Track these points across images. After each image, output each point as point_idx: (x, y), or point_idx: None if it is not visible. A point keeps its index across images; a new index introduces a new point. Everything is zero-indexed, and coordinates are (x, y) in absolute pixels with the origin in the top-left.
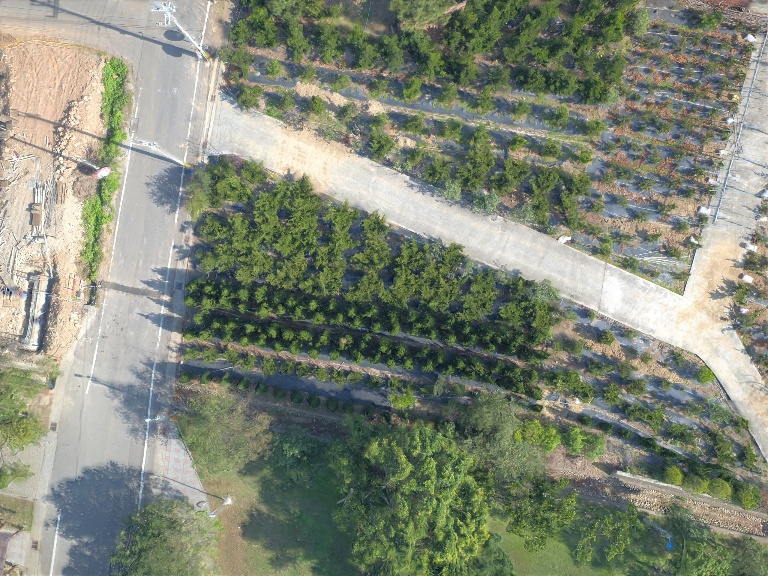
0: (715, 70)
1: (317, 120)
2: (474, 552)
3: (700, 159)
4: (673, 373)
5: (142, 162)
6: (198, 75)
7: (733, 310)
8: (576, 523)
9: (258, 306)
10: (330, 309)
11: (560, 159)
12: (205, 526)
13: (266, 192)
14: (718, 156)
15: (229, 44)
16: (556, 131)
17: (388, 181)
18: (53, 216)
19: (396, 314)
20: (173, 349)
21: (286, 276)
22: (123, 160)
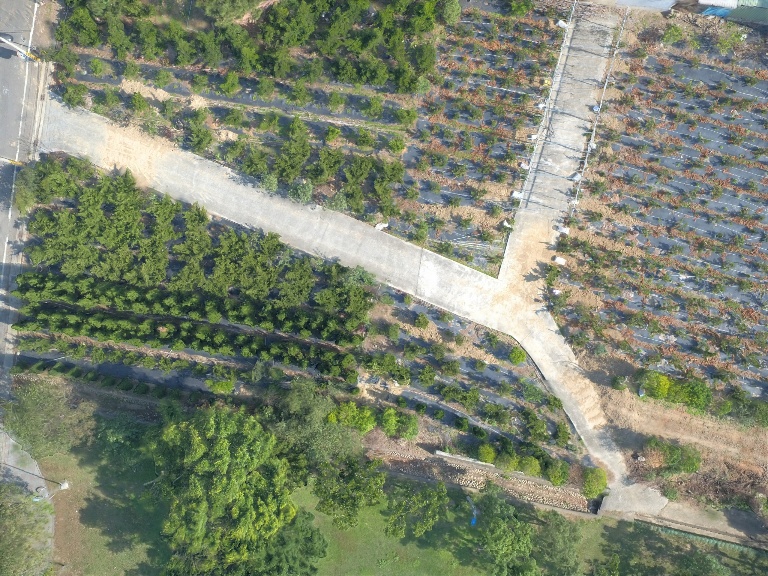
0: (528, 56)
1: (142, 116)
2: (272, 530)
3: (513, 144)
4: (489, 354)
5: None
6: (27, 75)
7: (547, 292)
8: (389, 501)
9: None
10: (151, 299)
11: (376, 148)
12: (34, 510)
13: None
14: (530, 141)
15: (57, 44)
16: (373, 121)
17: (210, 174)
18: None
19: (215, 302)
20: (10, 341)
21: (111, 268)
22: None
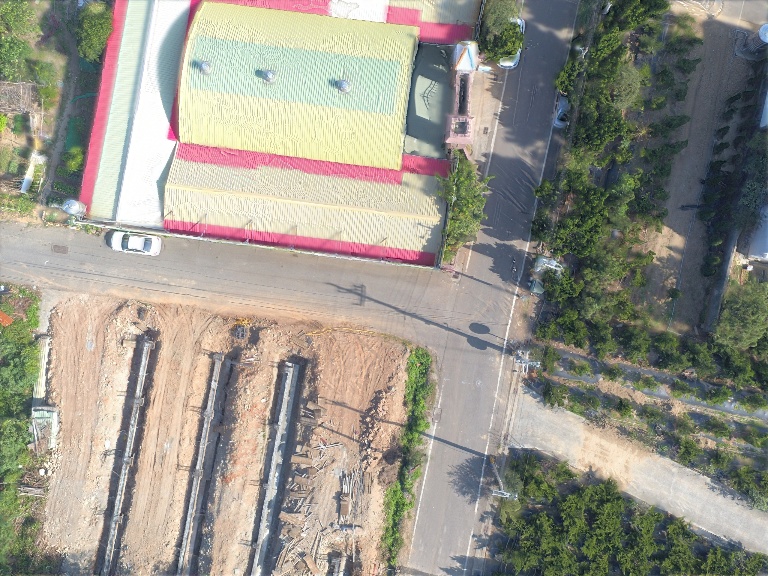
0: None
1: (619, 417)
2: None
3: None
4: None
5: (444, 452)
6: (502, 368)
7: None
8: None
9: None
10: None
11: None
12: None
13: (572, 493)
14: None
15: (532, 337)
16: None
17: (689, 482)
18: (359, 505)
19: None
20: None
21: None
22: (425, 449)
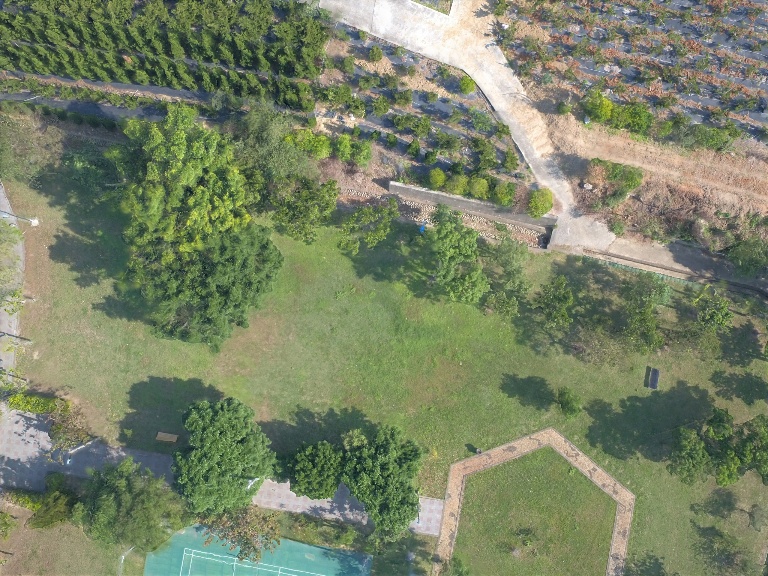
0: None
1: None
2: (227, 221)
3: None
4: (441, 88)
5: None
6: None
7: (496, 27)
8: None
9: None
10: (117, 33)
11: None
12: (4, 231)
13: None
14: None
15: None
16: None
17: None
18: None
19: (178, 36)
20: None
21: (79, 7)
22: None
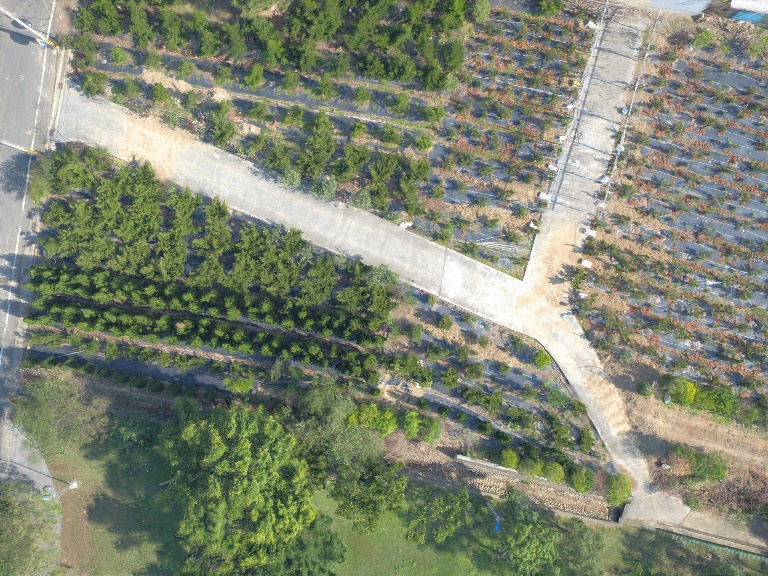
0: (557, 57)
1: (163, 107)
2: (292, 533)
3: (540, 145)
4: (513, 358)
5: None
6: (45, 63)
7: (572, 295)
8: (410, 506)
9: (97, 291)
10: (169, 294)
11: (402, 145)
12: (42, 509)
13: None
14: (558, 142)
15: (77, 32)
16: (399, 118)
17: (232, 167)
18: None
19: (234, 299)
20: (20, 335)
21: (128, 262)
22: None
